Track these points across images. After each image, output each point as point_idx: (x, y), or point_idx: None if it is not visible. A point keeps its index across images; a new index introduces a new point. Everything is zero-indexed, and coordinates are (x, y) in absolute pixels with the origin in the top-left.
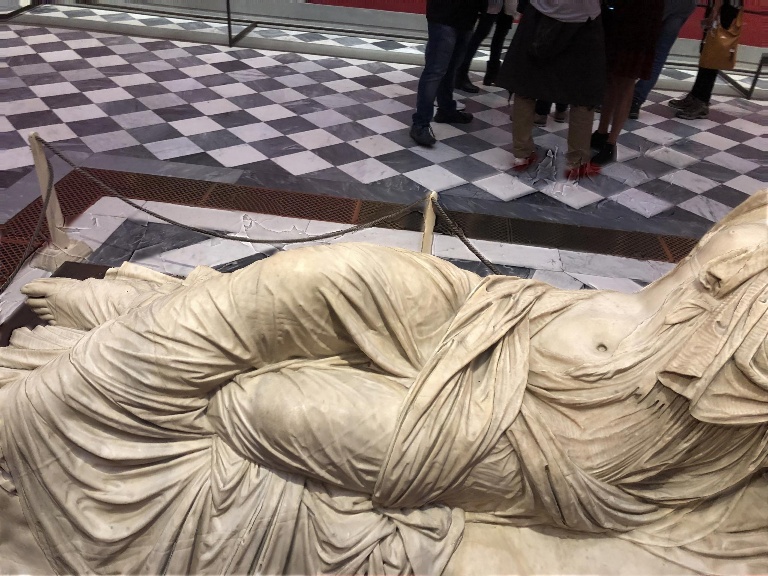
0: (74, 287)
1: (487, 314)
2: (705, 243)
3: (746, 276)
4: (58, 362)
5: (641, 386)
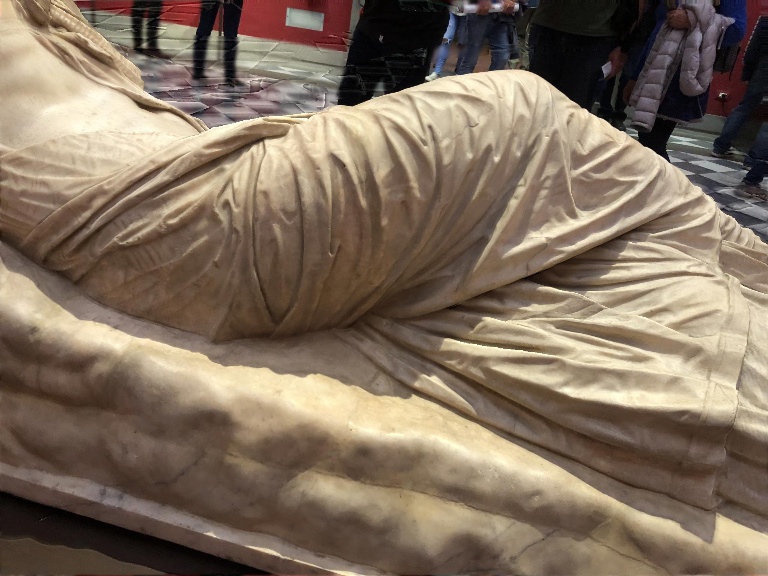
0: None
1: None
2: None
3: None
4: None
5: None
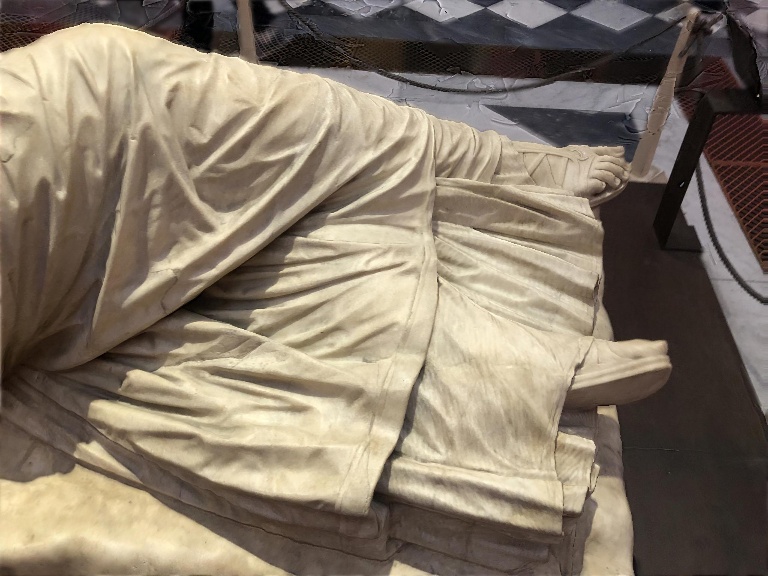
0: (574, 346)
1: None
2: None
3: None
4: (442, 124)
5: None
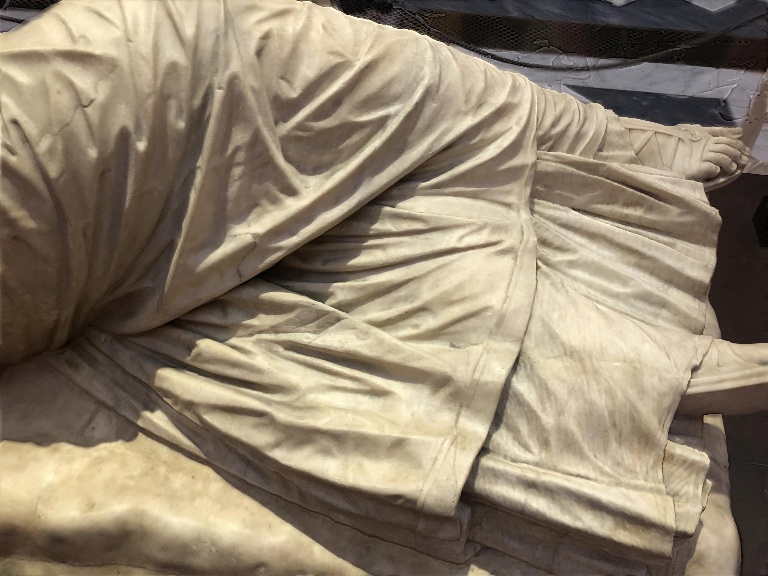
0: (691, 345)
1: None
2: None
3: None
4: (545, 92)
5: None
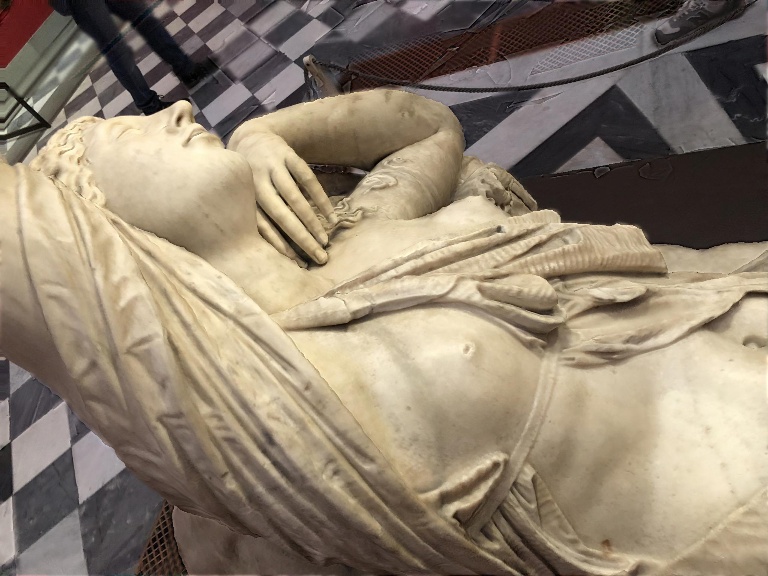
0: None
1: None
2: (491, 452)
3: (499, 269)
4: None
5: (694, 273)
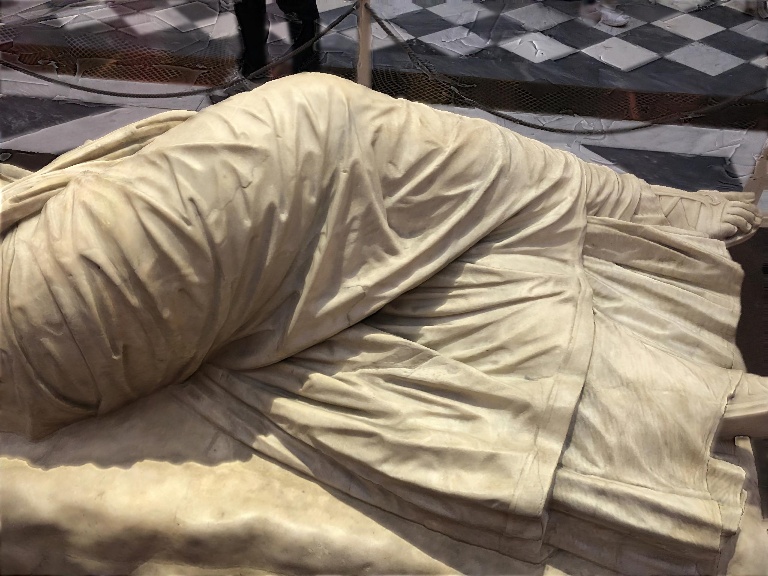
0: (725, 377)
1: (64, 159)
2: None
3: None
4: None
5: None
